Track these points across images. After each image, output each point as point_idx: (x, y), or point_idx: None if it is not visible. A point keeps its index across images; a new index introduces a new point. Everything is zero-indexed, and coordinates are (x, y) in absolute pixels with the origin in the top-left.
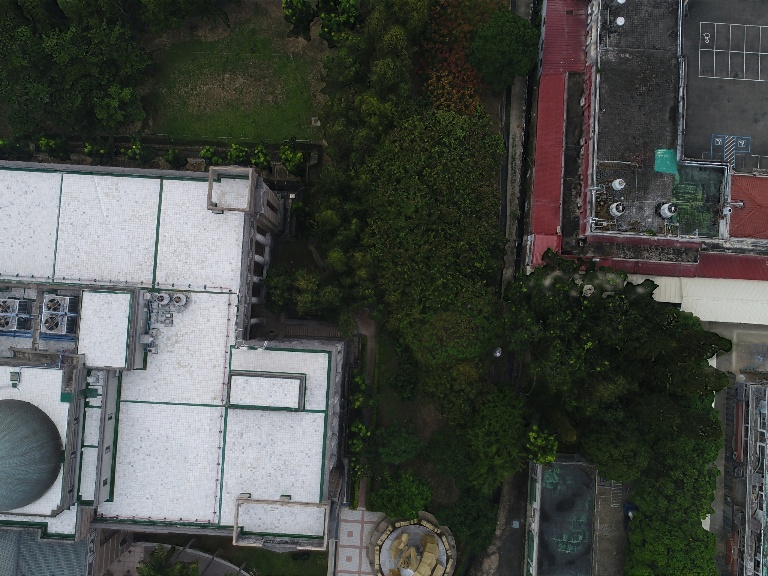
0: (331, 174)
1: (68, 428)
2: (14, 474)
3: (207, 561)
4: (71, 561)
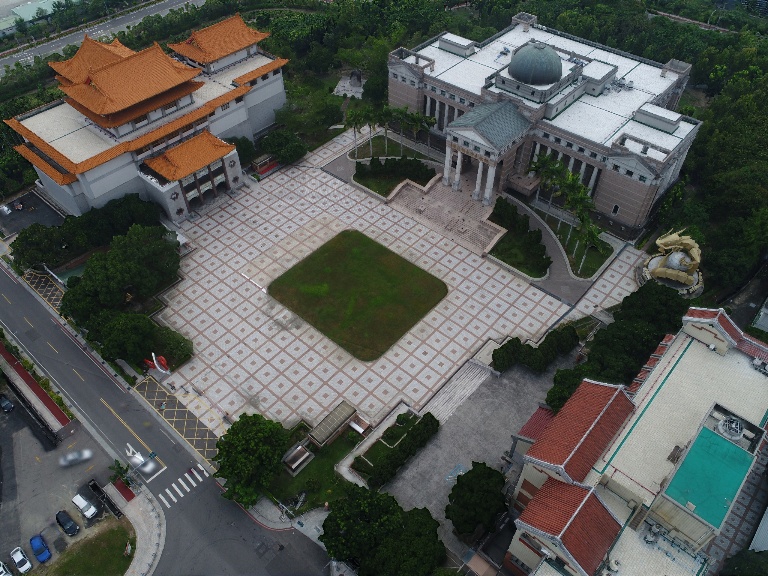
0: (718, 102)
1: (567, 76)
2: (552, 58)
3: (535, 220)
4: (519, 125)
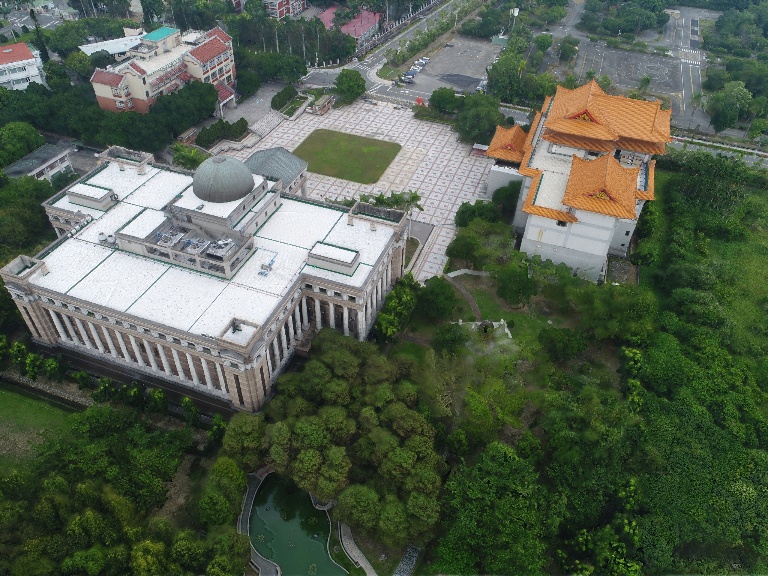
0: None
1: (187, 187)
2: None
3: None
4: None
